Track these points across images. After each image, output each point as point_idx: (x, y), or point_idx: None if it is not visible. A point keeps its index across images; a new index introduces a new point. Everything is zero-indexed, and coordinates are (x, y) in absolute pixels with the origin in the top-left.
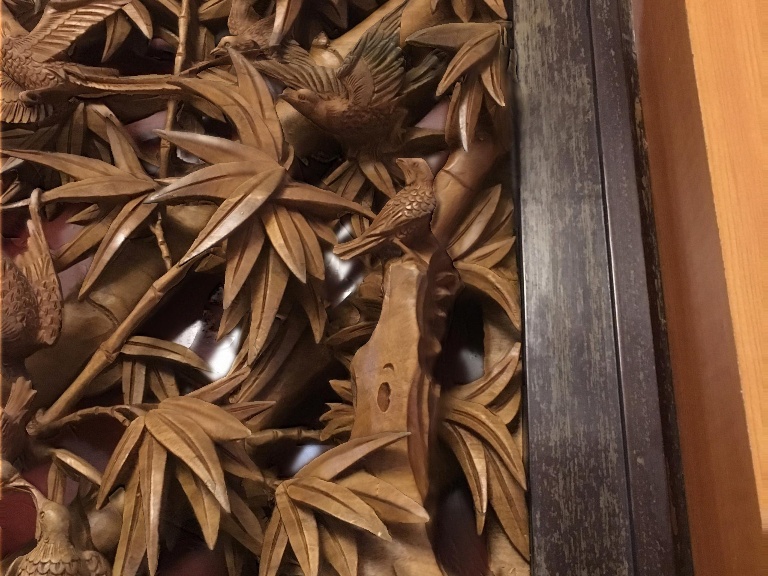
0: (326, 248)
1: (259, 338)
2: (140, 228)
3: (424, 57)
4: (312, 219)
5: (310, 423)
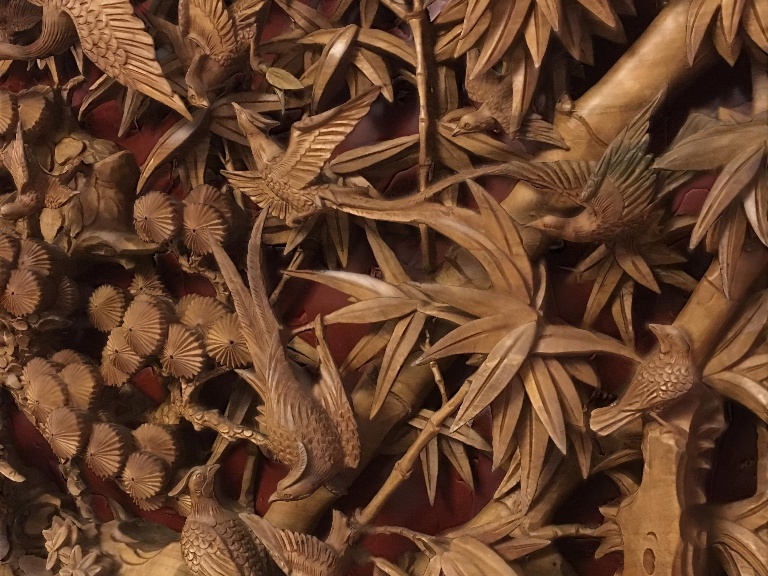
0: (585, 392)
1: (529, 488)
2: (412, 351)
3: (682, 117)
4: (569, 362)
5: (586, 522)
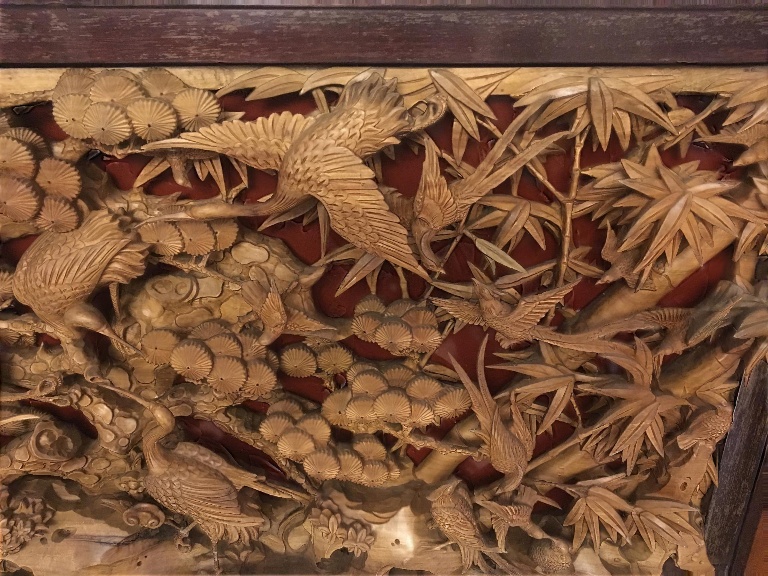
0: None
1: (632, 465)
2: None
3: (717, 278)
4: None
5: None
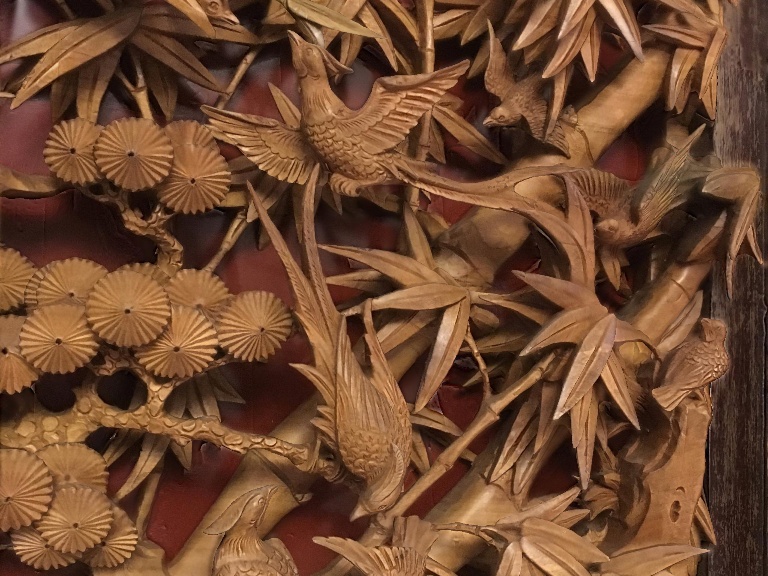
0: None
1: (588, 465)
2: None
3: (649, 148)
4: None
5: (560, 491)
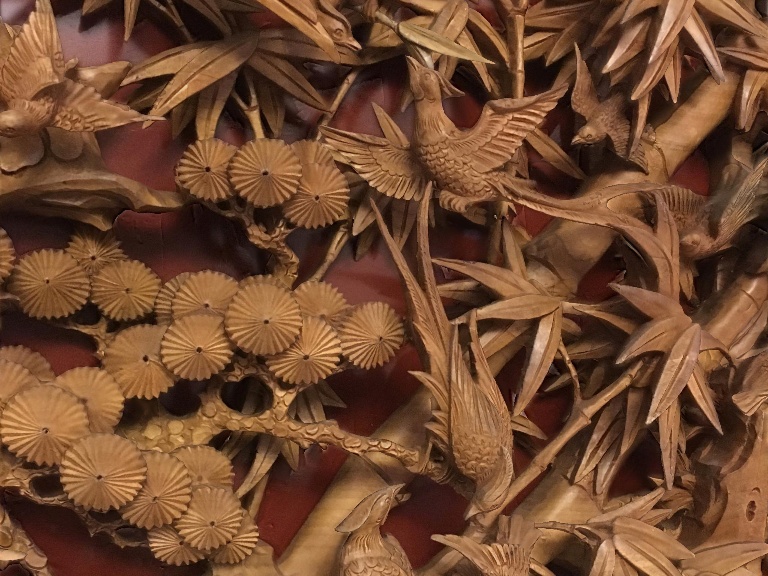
0: None
1: (672, 467)
2: None
3: (719, 165)
4: None
5: (637, 491)
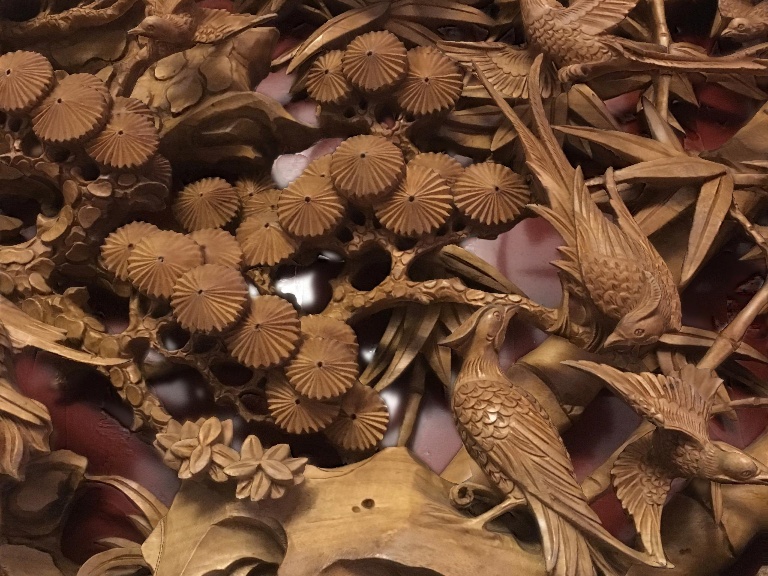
0: None
1: None
2: None
3: None
4: None
5: None
